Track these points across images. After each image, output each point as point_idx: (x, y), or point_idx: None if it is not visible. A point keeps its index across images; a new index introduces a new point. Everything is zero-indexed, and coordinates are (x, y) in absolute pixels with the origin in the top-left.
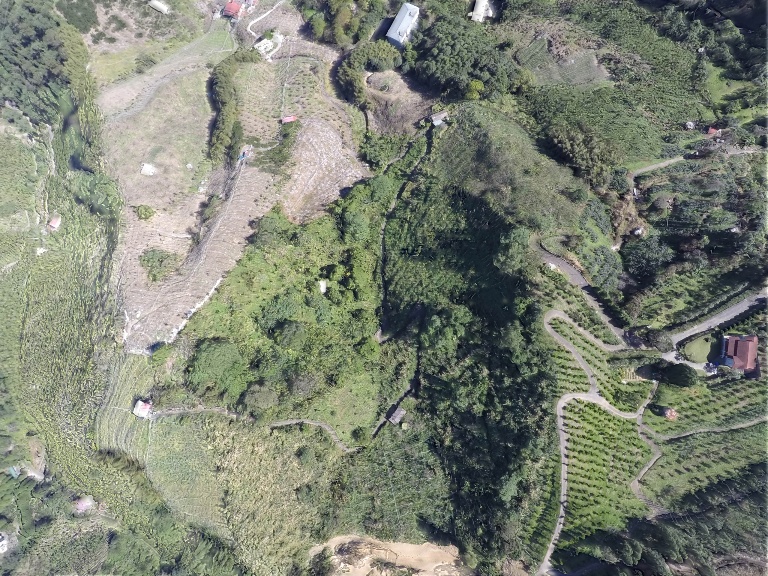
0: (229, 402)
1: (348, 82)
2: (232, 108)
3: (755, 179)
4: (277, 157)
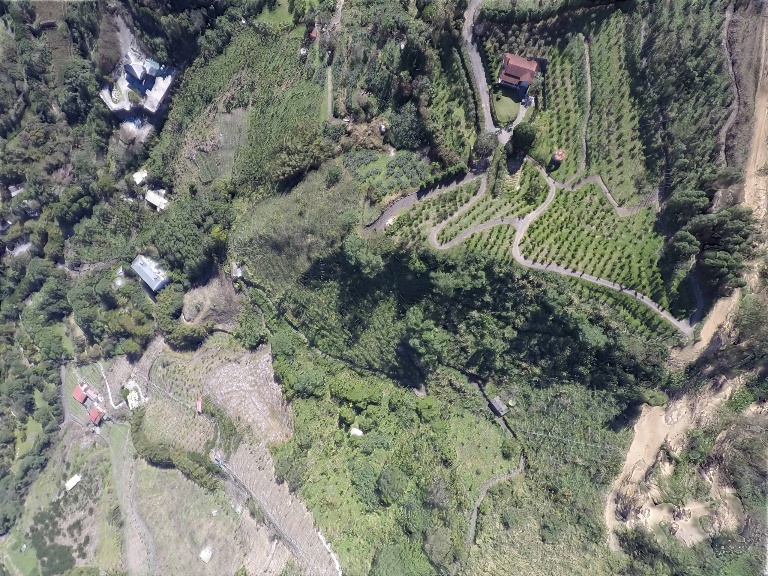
0: None
1: (183, 338)
2: (174, 454)
3: (367, 6)
4: (228, 431)
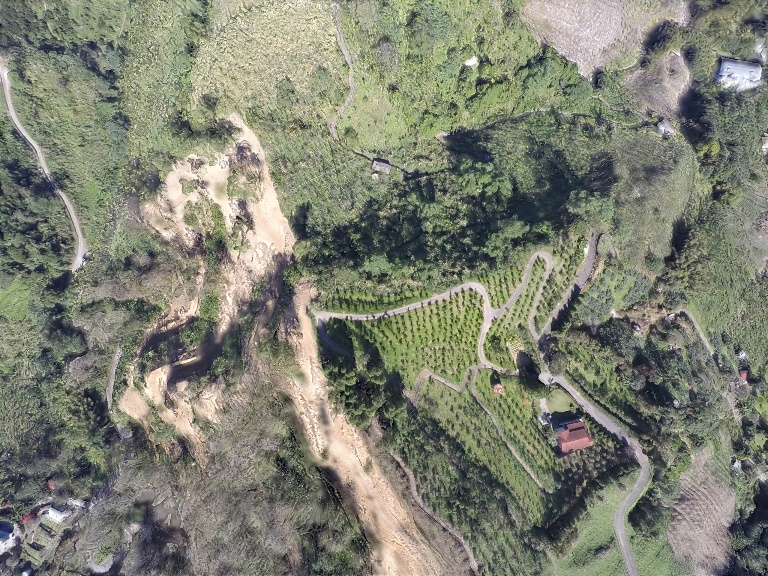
0: None
1: (664, 34)
2: None
3: None
4: None
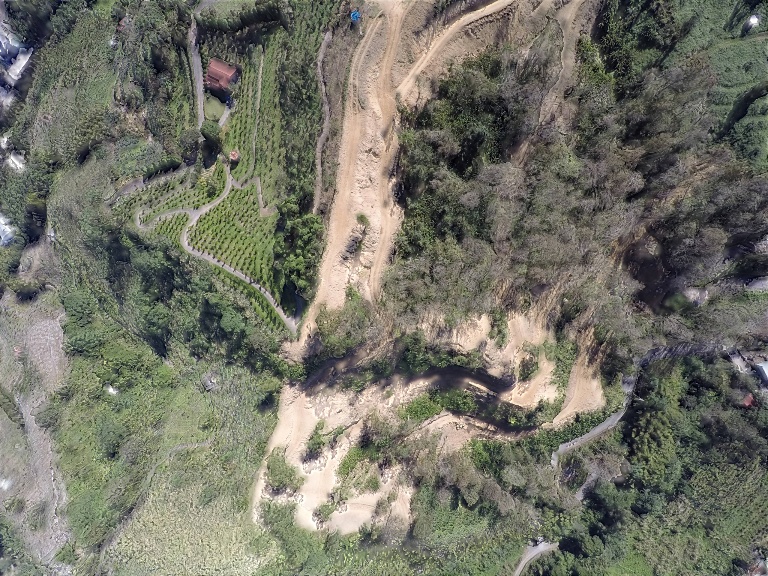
0: (100, 522)
1: (18, 286)
2: None
3: None
4: None
